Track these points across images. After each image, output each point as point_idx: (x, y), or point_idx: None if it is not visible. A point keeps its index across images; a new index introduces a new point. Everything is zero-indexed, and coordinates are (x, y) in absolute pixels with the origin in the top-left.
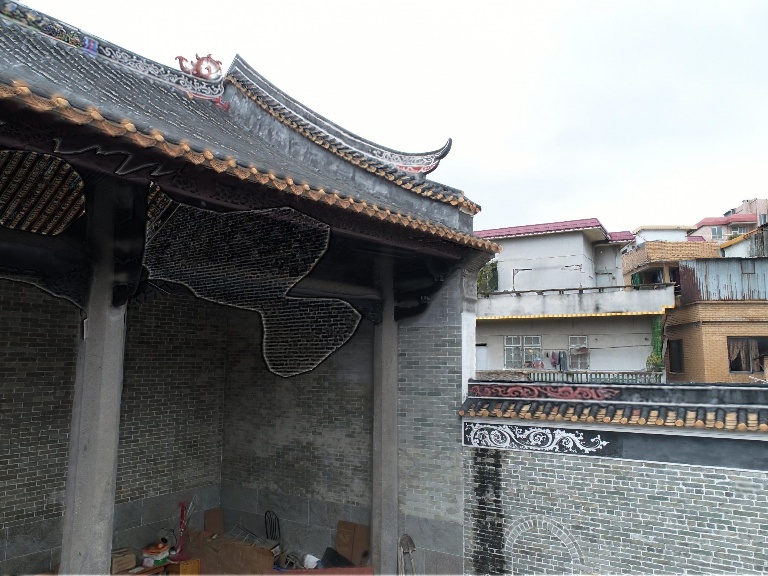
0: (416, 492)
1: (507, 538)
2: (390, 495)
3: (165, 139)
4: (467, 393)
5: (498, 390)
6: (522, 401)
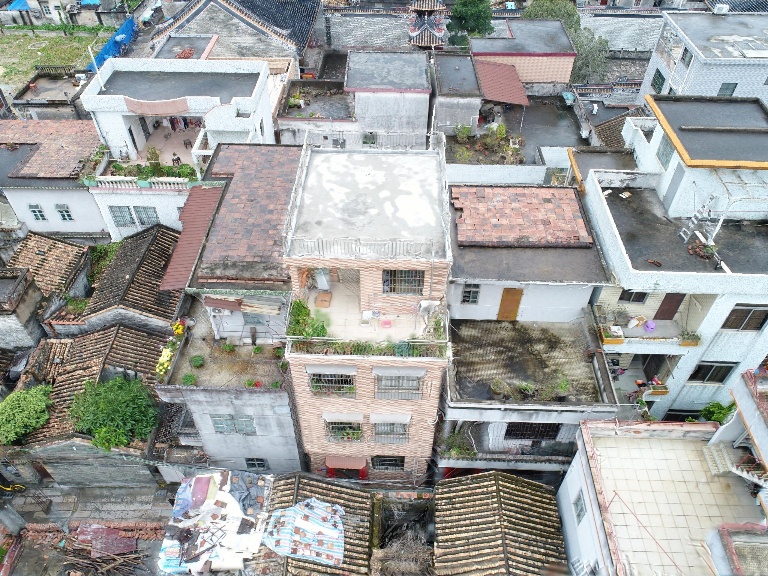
0: (316, 24)
1: (331, 29)
2: None
3: (317, 6)
4: (323, 8)
5: (328, 7)
6: (332, 9)
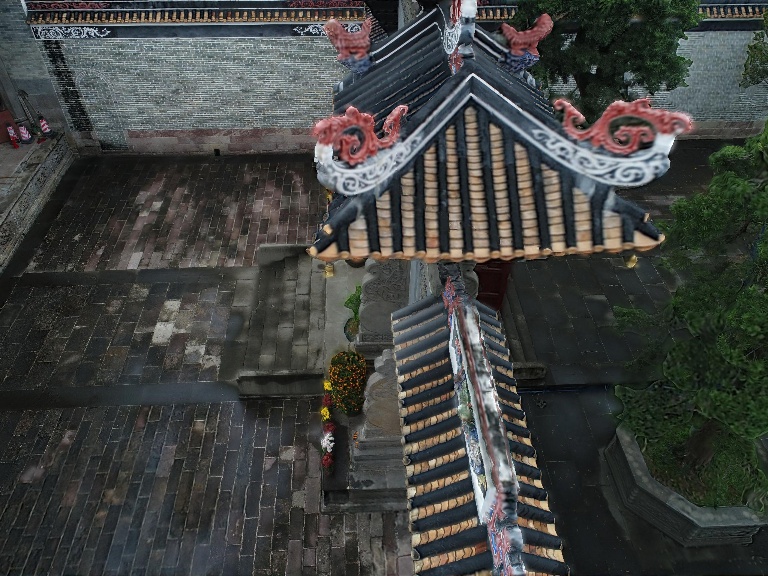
0: (17, 67)
1: (75, 81)
2: (3, 73)
3: None
4: (27, 8)
5: (45, 6)
6: (61, 11)
